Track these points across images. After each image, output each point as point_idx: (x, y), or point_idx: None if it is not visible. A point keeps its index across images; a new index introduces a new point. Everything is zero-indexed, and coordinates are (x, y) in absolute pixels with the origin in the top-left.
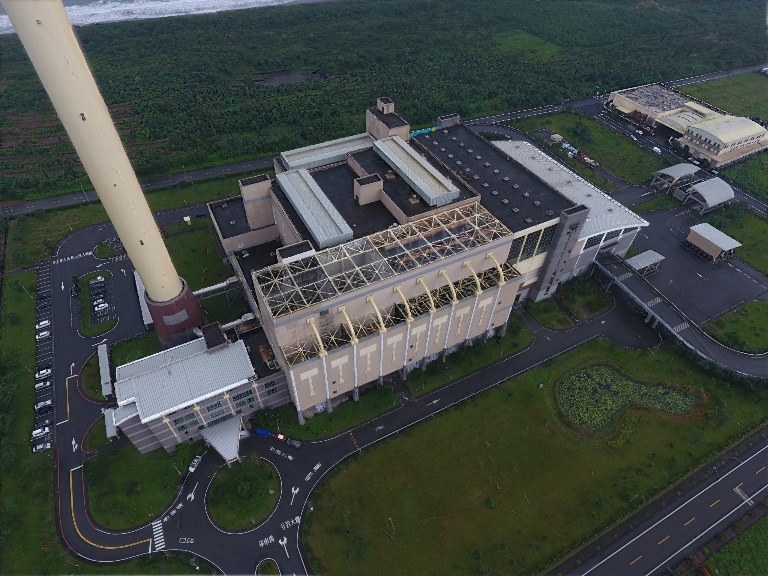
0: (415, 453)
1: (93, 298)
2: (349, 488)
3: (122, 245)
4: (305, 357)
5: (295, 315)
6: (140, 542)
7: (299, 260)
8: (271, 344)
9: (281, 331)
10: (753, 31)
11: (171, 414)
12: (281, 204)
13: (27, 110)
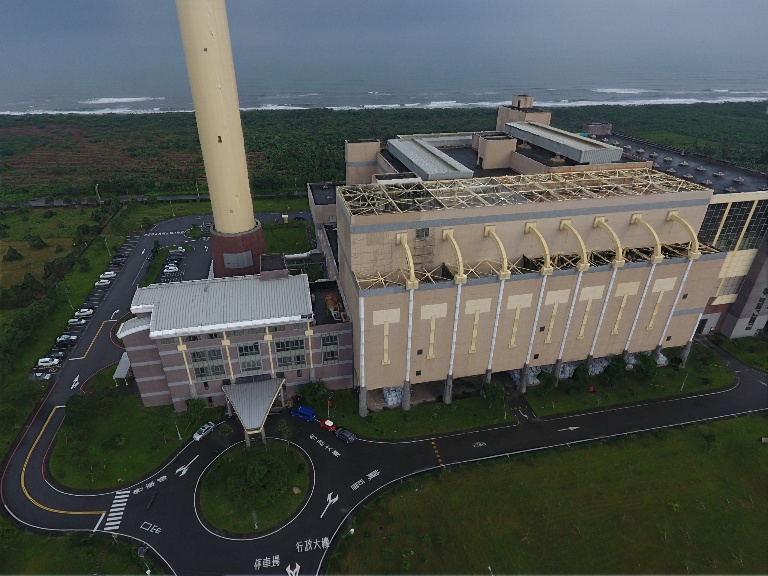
0: (537, 490)
1: (167, 262)
2: (419, 515)
3: None
4: (385, 285)
5: (382, 220)
6: (89, 512)
7: (399, 184)
8: (343, 296)
9: (359, 243)
10: None
11: (191, 340)
12: (388, 160)
13: (179, 150)
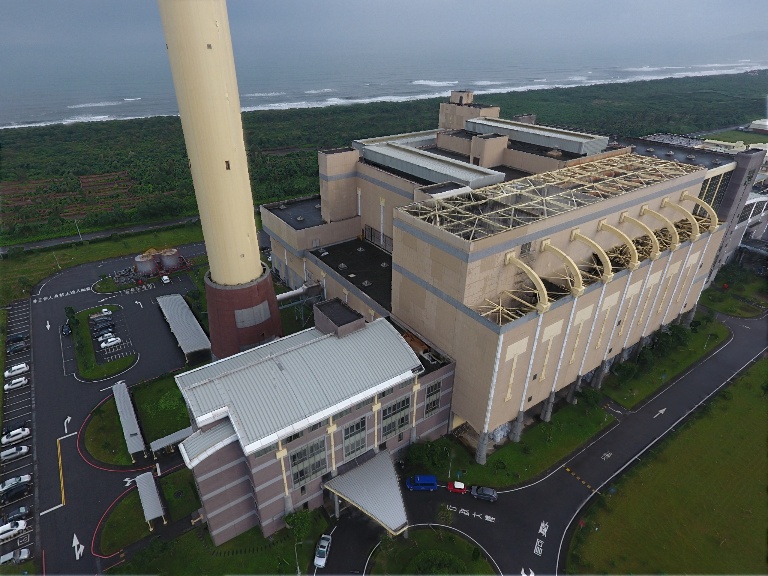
0: (689, 486)
1: (97, 333)
2: (623, 558)
3: (135, 274)
4: (514, 315)
5: (495, 242)
6: None
7: (454, 197)
8: (416, 333)
9: (473, 272)
10: (708, 109)
11: (291, 439)
12: None
13: None
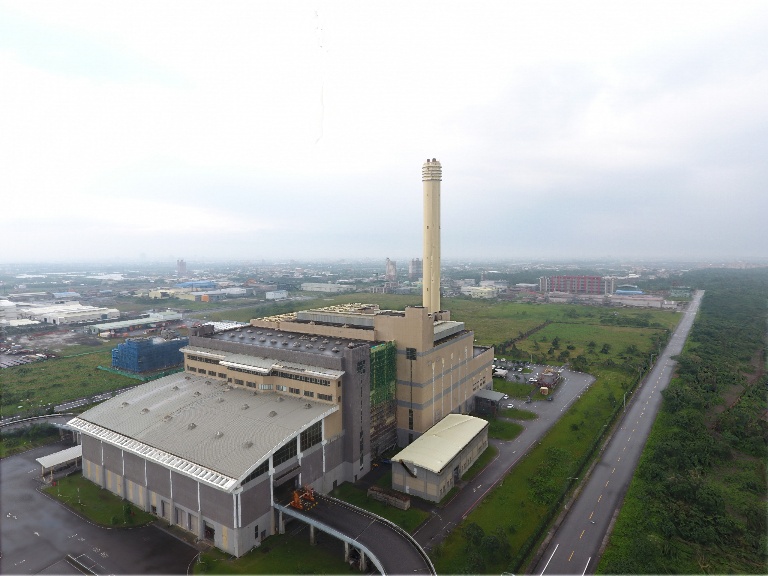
0: None
1: None
2: None
3: None
4: None
5: None
6: None
7: None
8: None
9: None
10: None
11: None
12: None
13: None
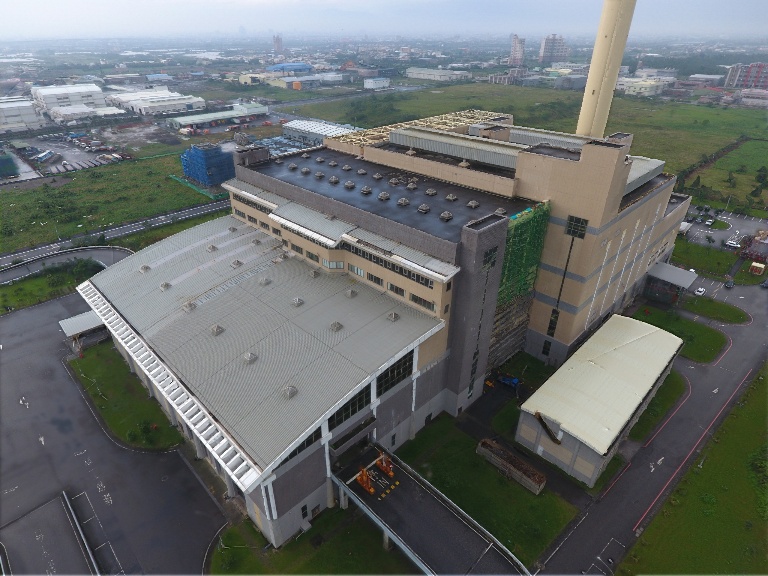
0: None
1: None
2: None
3: (752, 235)
4: None
5: None
6: None
7: None
8: None
9: None
10: None
11: None
12: None
13: None
